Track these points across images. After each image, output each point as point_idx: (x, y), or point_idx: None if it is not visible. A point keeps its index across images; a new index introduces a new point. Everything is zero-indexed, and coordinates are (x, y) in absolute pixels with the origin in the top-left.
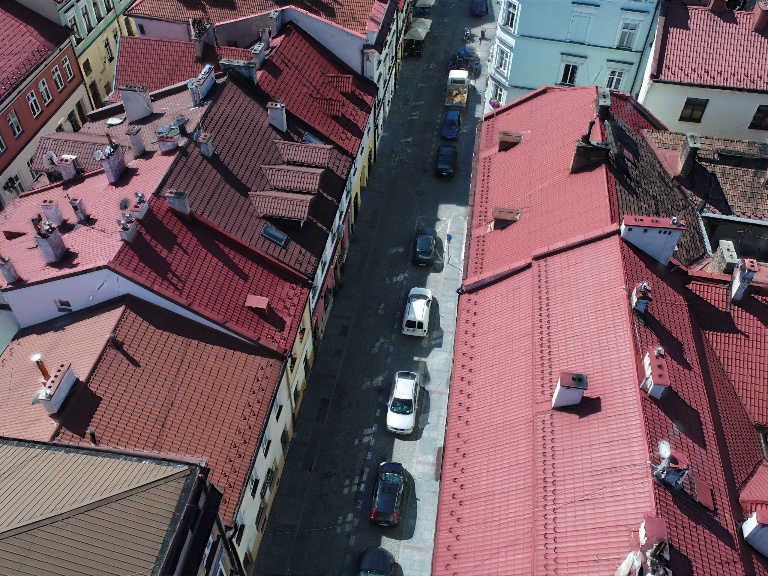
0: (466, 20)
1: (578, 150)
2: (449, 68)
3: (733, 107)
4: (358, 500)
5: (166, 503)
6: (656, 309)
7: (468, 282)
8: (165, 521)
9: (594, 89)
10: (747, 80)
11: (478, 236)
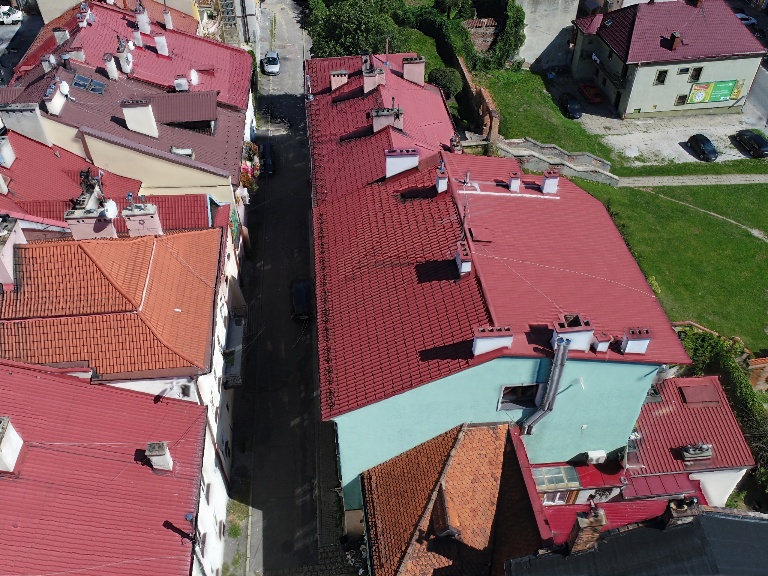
0: None
1: None
2: None
3: None
4: None
5: None
6: None
7: None
8: None
9: None
10: None
11: None
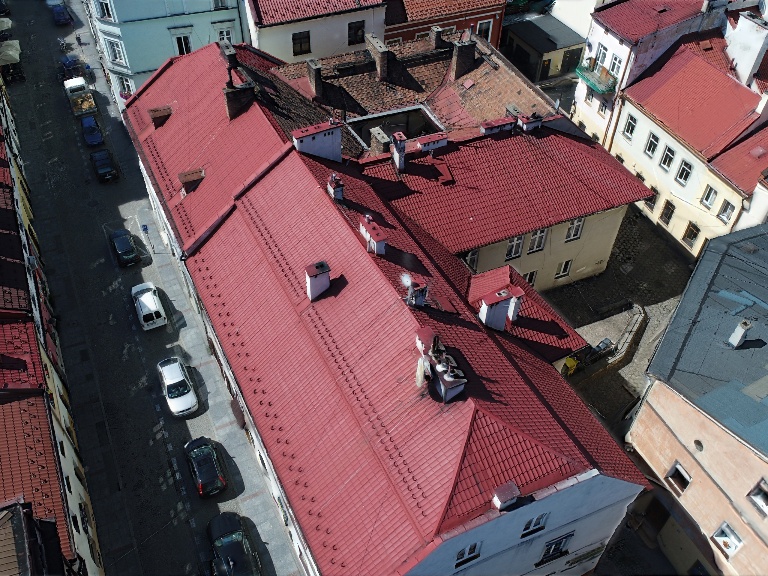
0: (54, 32)
1: (228, 97)
2: (60, 81)
3: (330, 31)
4: (180, 488)
5: (3, 552)
6: (350, 195)
7: (187, 246)
8: (12, 567)
9: (215, 45)
10: (331, 6)
11: (175, 206)
